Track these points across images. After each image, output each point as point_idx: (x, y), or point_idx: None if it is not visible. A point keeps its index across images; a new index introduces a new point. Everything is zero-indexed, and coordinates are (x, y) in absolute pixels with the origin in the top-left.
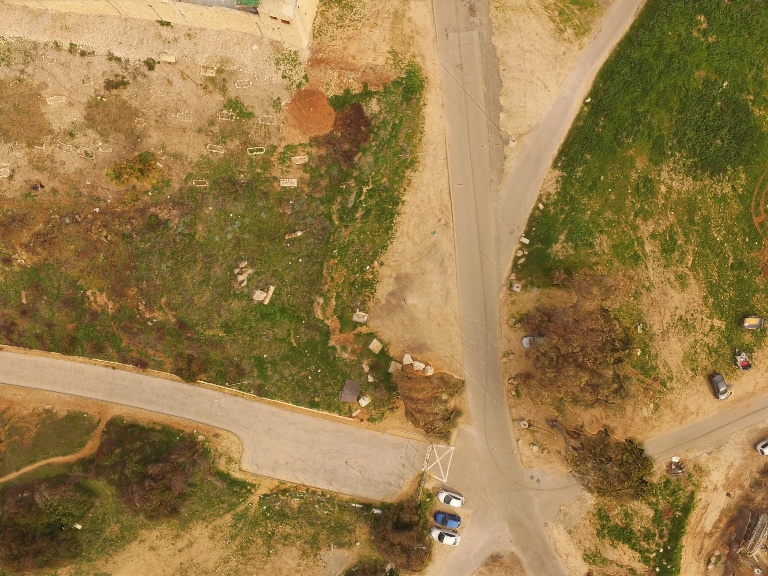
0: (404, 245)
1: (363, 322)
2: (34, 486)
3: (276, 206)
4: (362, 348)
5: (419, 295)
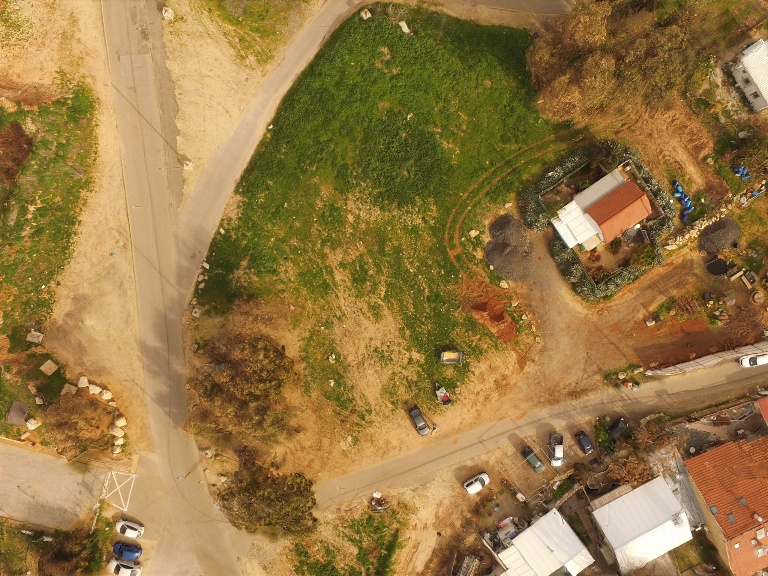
0: (82, 265)
1: (38, 342)
2: None
3: None
4: (31, 369)
5: (97, 317)
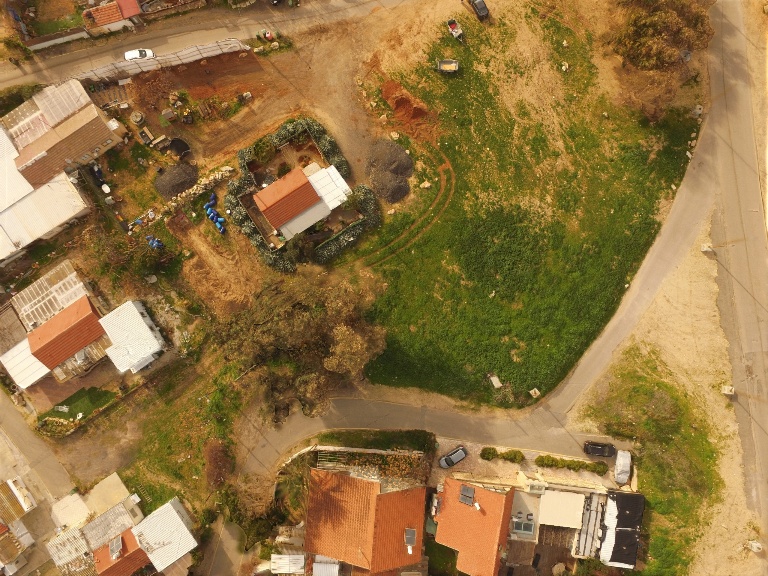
0: None
1: None
2: None
3: None
4: None
5: None
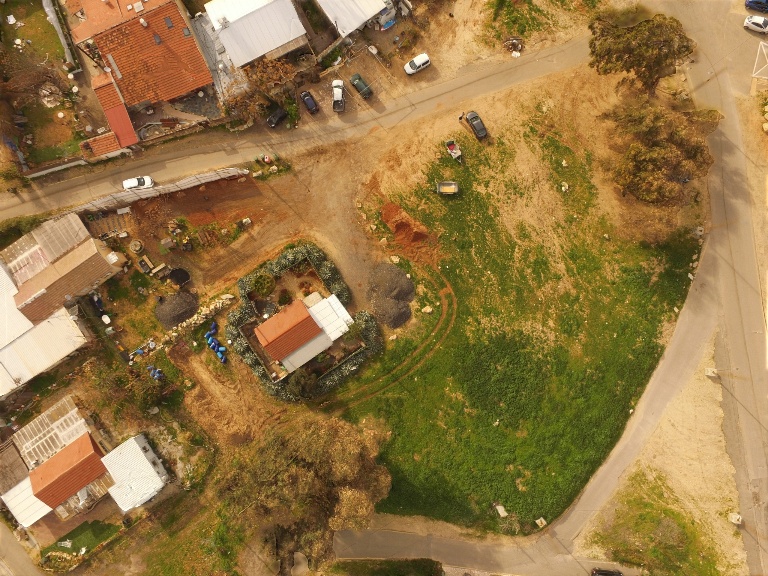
0: None
1: None
2: None
3: None
4: None
5: None
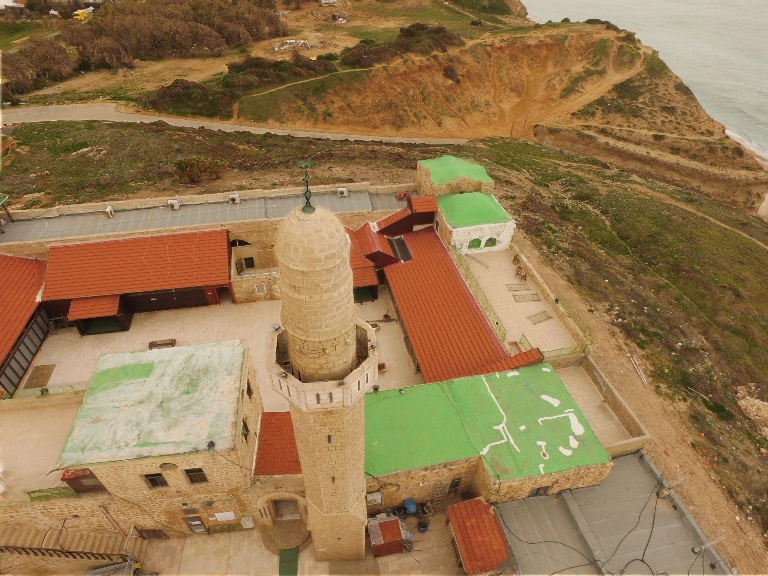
0: None
1: None
2: (263, 84)
3: None
4: None
5: None
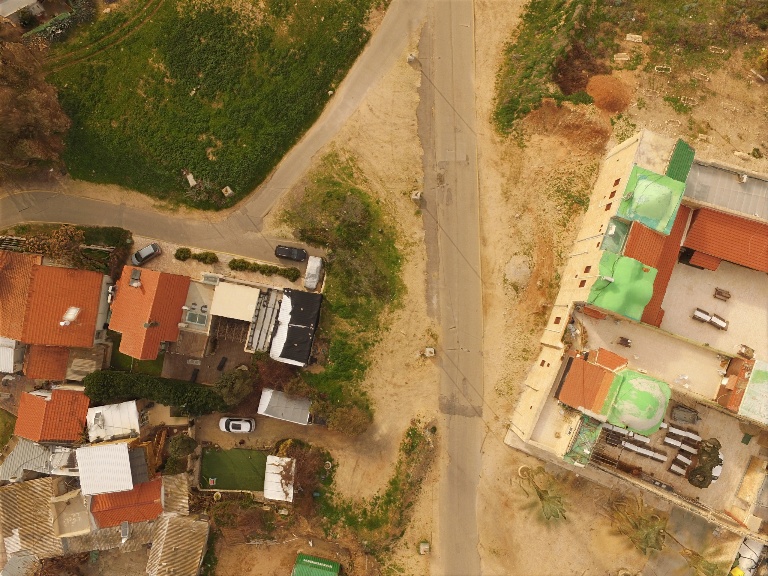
0: None
1: None
2: None
3: (648, 18)
4: None
5: None
